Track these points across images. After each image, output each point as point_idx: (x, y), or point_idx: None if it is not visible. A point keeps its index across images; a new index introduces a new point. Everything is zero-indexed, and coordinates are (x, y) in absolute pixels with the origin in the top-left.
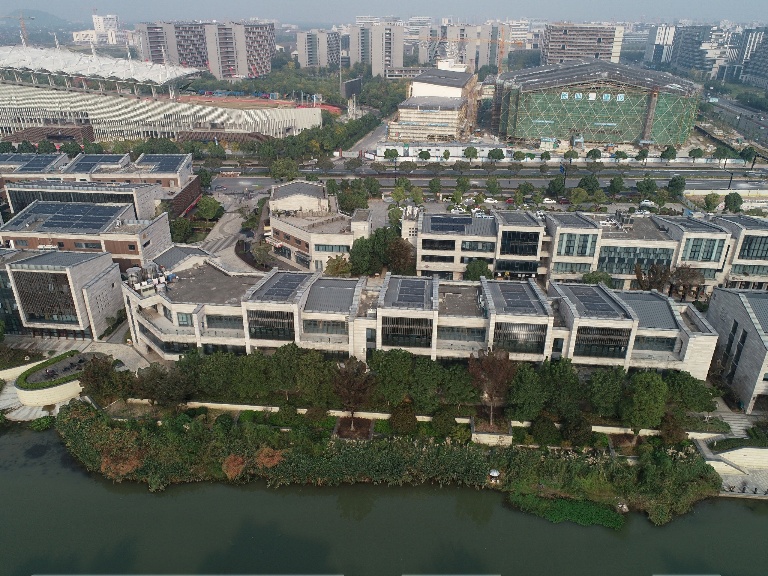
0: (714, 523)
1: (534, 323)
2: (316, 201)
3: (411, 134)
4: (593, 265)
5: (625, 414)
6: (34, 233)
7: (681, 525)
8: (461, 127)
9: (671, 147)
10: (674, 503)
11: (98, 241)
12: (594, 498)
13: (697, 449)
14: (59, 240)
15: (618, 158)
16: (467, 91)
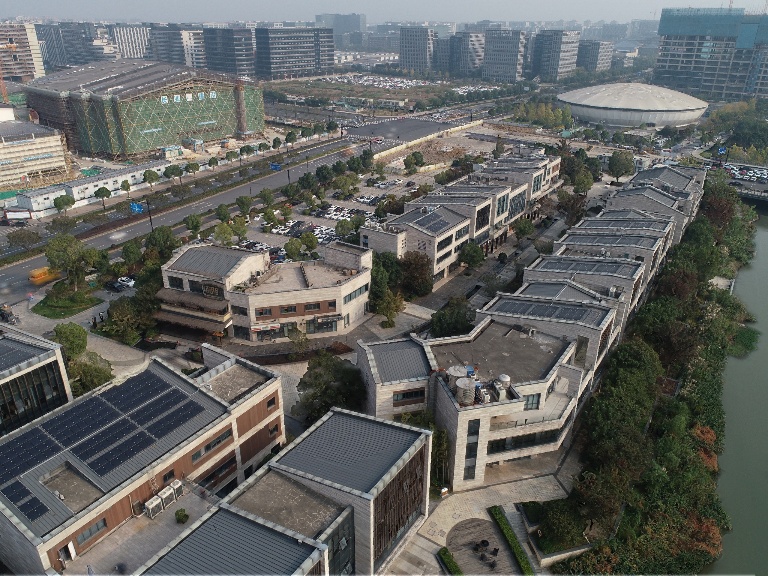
0: None
1: None
2: (261, 258)
3: (2, 177)
4: None
5: (708, 276)
6: (121, 491)
7: None
8: (69, 154)
9: (292, 131)
10: None
11: (227, 426)
12: (735, 329)
13: None
14: (166, 470)
15: (263, 150)
16: (22, 111)
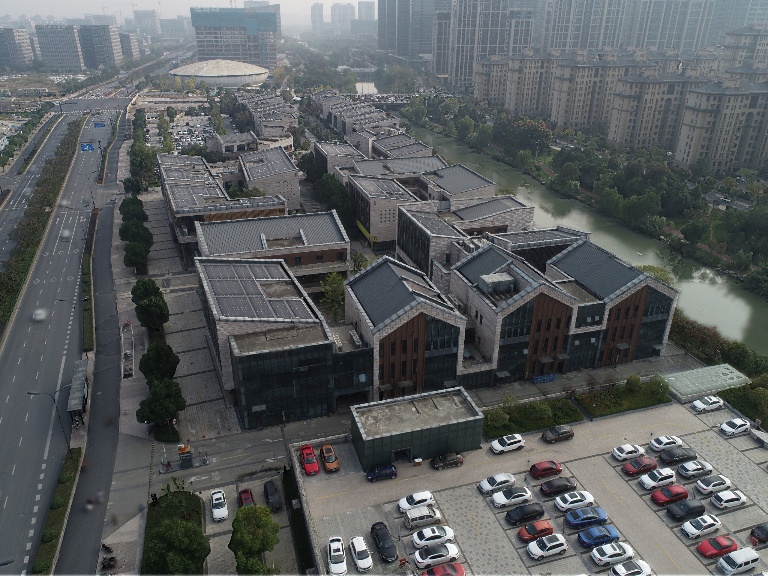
0: None
1: None
2: None
3: None
4: None
5: None
6: None
7: None
8: None
9: (39, 109)
10: None
11: None
12: None
13: None
14: None
15: None
16: None
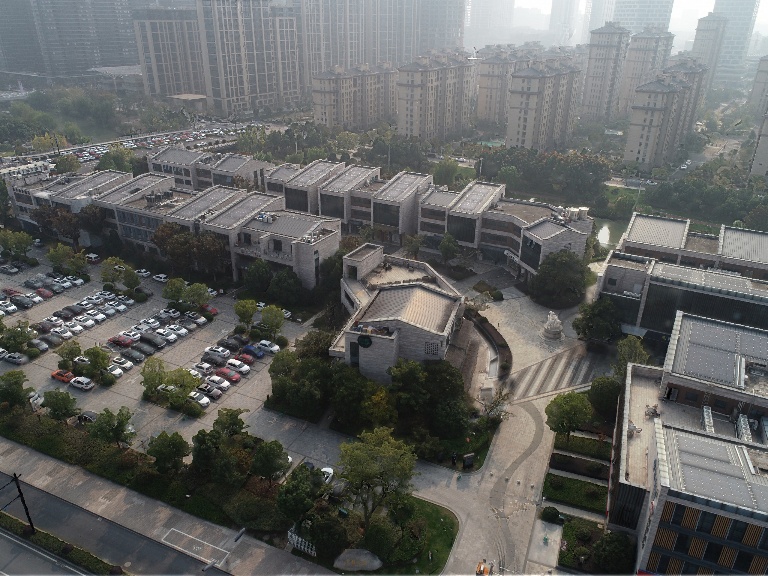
0: None
1: None
2: None
3: None
4: None
5: None
6: None
7: None
8: None
9: None
10: None
11: None
12: None
13: None
14: None
15: None
16: None
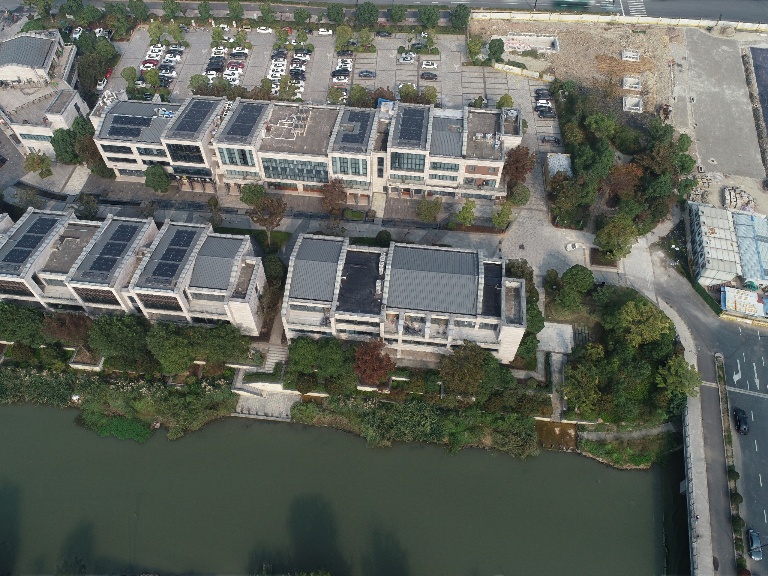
0: (213, 437)
1: (102, 289)
2: (31, 71)
3: None
4: (260, 172)
5: None
6: None
7: (189, 439)
8: None
9: None
10: (187, 425)
11: None
12: (140, 417)
13: (233, 378)
14: None
15: None
16: None
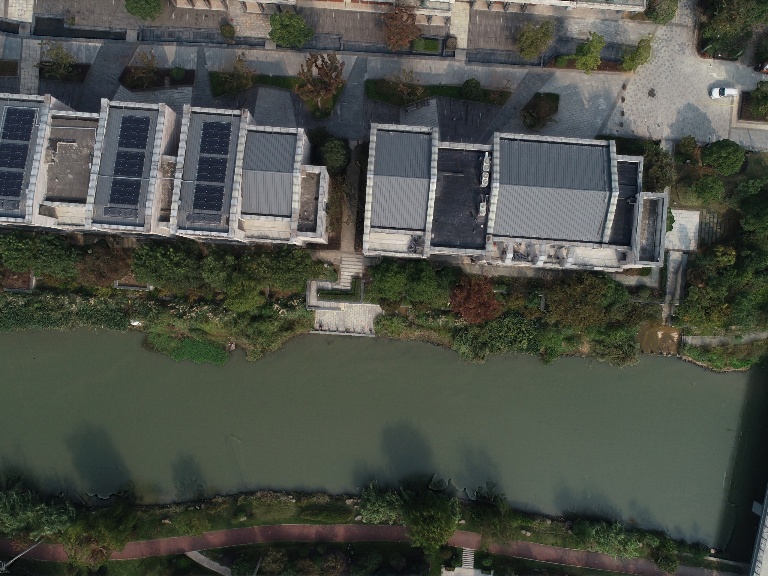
0: (295, 356)
1: None
2: None
3: None
4: None
5: None
6: None
7: (269, 359)
8: None
9: None
10: None
11: None
12: (211, 339)
13: (306, 295)
14: None
15: None
16: None
